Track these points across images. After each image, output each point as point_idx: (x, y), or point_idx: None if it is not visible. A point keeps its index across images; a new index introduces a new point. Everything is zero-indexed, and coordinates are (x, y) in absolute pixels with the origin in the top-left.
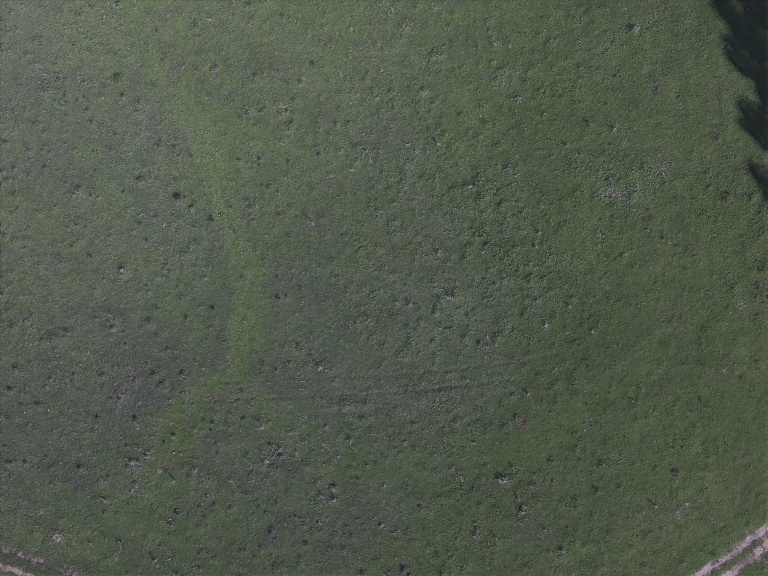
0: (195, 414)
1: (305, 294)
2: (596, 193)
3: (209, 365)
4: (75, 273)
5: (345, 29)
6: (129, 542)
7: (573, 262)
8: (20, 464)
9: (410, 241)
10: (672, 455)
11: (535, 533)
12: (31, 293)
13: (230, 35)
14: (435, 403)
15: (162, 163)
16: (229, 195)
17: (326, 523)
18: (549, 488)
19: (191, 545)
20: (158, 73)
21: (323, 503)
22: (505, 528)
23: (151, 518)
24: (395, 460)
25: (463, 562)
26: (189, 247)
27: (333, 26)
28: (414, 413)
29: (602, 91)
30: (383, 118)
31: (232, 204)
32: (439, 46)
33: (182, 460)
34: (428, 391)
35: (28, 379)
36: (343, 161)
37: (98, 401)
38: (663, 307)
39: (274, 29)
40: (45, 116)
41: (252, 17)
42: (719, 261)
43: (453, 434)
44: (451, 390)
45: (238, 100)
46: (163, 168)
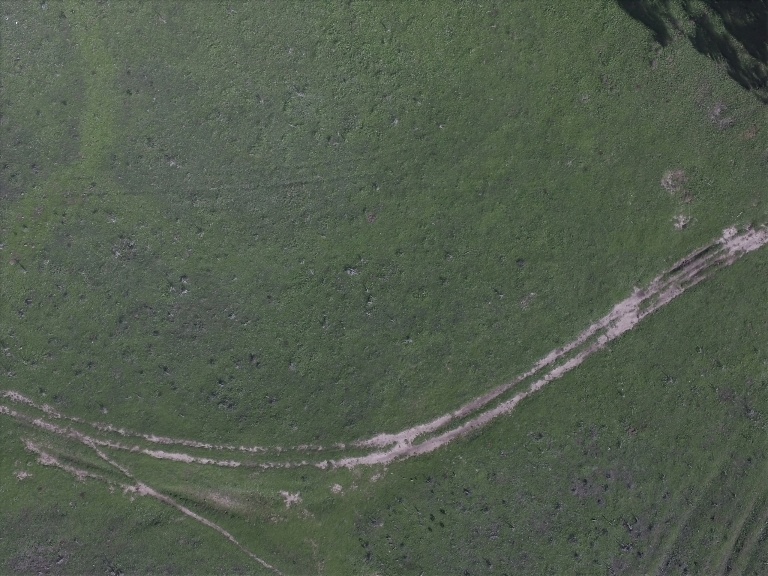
0: (47, 208)
1: (157, 91)
2: None
3: (62, 160)
4: None
5: None
6: None
7: (422, 59)
8: None
9: (262, 40)
10: (518, 246)
11: (383, 323)
12: None
13: None
14: (286, 198)
15: None
16: None
17: (178, 315)
18: (398, 280)
19: (42, 335)
20: None
21: (175, 295)
22: (354, 318)
23: (3, 308)
24: (246, 253)
25: (312, 352)
26: (41, 44)
27: None
28: (265, 208)
29: None
30: None
31: (84, 1)
32: None
33: (34, 252)
34: (279, 186)
35: None
36: None
37: None
38: (510, 102)
39: None
40: None
41: None
42: (564, 56)
43: (303, 228)
44: (302, 185)
45: None
46: None
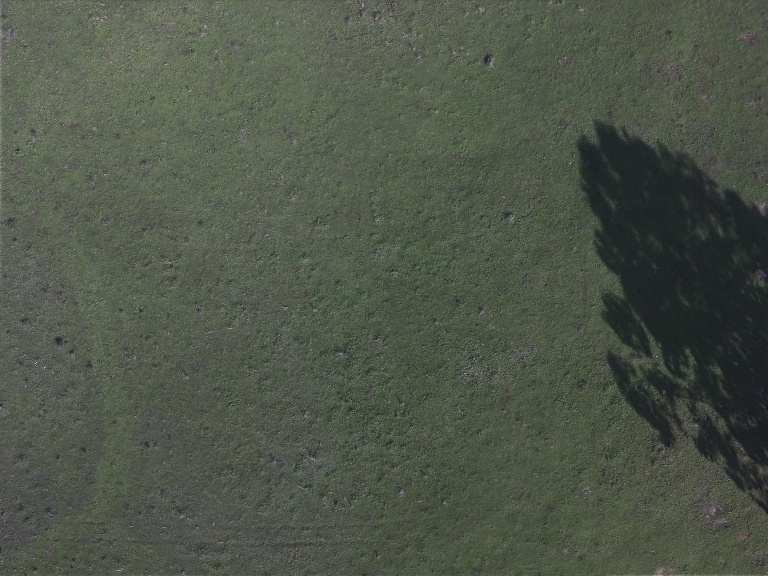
0: (59, 551)
1: (174, 444)
2: (459, 371)
3: (76, 505)
4: None
5: (235, 192)
6: None
7: (432, 435)
8: None
9: (279, 400)
10: None
11: None
12: None
13: (124, 190)
14: (289, 558)
15: (48, 308)
16: (109, 344)
17: None
18: None
19: None
20: (52, 221)
21: None
22: None
23: None
24: None
25: None
26: (67, 390)
27: (223, 189)
28: (268, 566)
29: (474, 273)
30: (264, 280)
31: (111, 353)
32: (324, 215)
33: None
34: (284, 546)
35: None
36: (222, 318)
37: None
38: (513, 485)
39: (167, 187)
40: None
41: (146, 175)
42: (570, 446)
43: None
44: (306, 547)
45: (126, 253)
46: (48, 312)
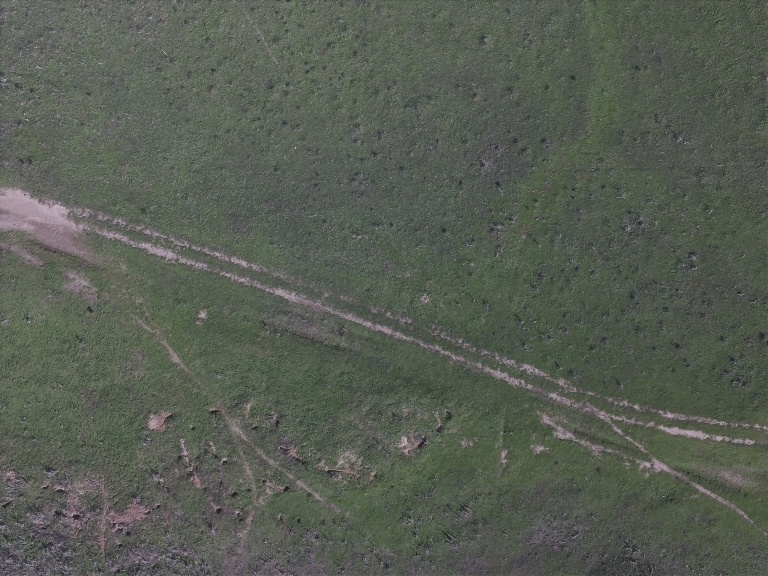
0: (557, 182)
1: (664, 67)
2: None
3: (570, 135)
4: (438, 43)
5: None
6: (496, 304)
7: None
8: (387, 227)
9: (767, 17)
10: None
11: None
12: (396, 62)
13: None
14: None
15: None
16: None
17: (686, 291)
18: None
19: (556, 309)
20: None
21: (683, 272)
22: None
23: (516, 282)
24: (754, 231)
25: None
26: (551, 19)
27: None
28: None
29: None
30: None
31: None
32: None
33: (546, 226)
34: None
35: (393, 145)
36: None
37: (462, 168)
38: None
39: None
40: None
41: None
42: None
43: None
44: None
45: None
46: None
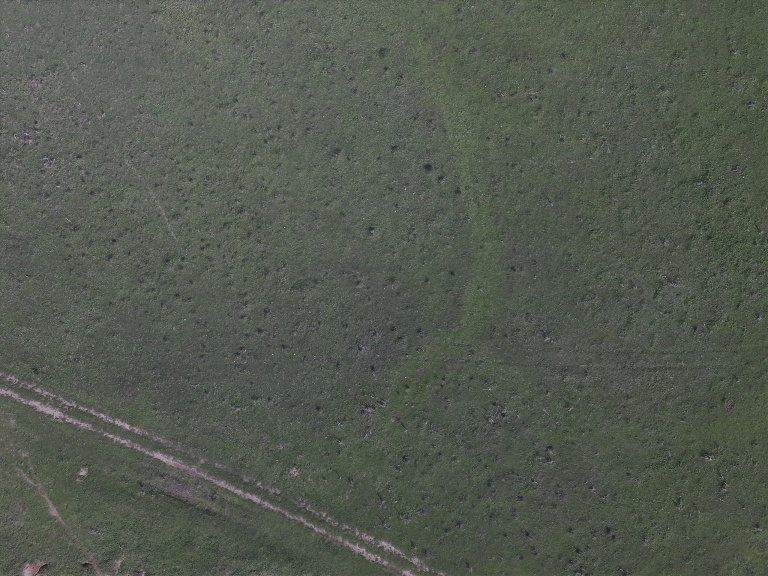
0: (428, 370)
1: (539, 269)
2: None
3: (444, 326)
4: (328, 230)
5: (596, 26)
6: (360, 483)
7: None
8: (265, 401)
9: (639, 229)
10: None
11: (735, 510)
12: (287, 245)
13: (490, 22)
14: (650, 381)
15: (417, 135)
16: (477, 171)
17: (541, 483)
18: (750, 470)
19: (417, 491)
20: (420, 52)
21: (539, 464)
22: (707, 503)
23: (382, 462)
24: (609, 430)
25: (665, 530)
26: (436, 216)
27: (585, 22)
28: (630, 389)
29: None
30: (623, 112)
31: (479, 179)
32: (681, 50)
33: (414, 412)
34: (644, 369)
35: (278, 324)
36: (583, 149)
37: (340, 350)
38: None
39: (530, 20)
40: (313, 82)
41: (512, 7)
42: None
43: (665, 411)
44: (666, 370)
45: (492, 83)
46: (417, 140)
